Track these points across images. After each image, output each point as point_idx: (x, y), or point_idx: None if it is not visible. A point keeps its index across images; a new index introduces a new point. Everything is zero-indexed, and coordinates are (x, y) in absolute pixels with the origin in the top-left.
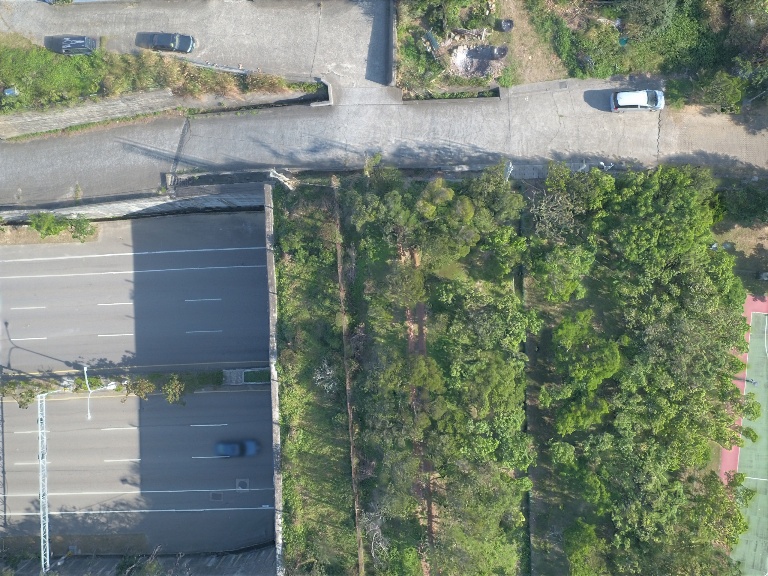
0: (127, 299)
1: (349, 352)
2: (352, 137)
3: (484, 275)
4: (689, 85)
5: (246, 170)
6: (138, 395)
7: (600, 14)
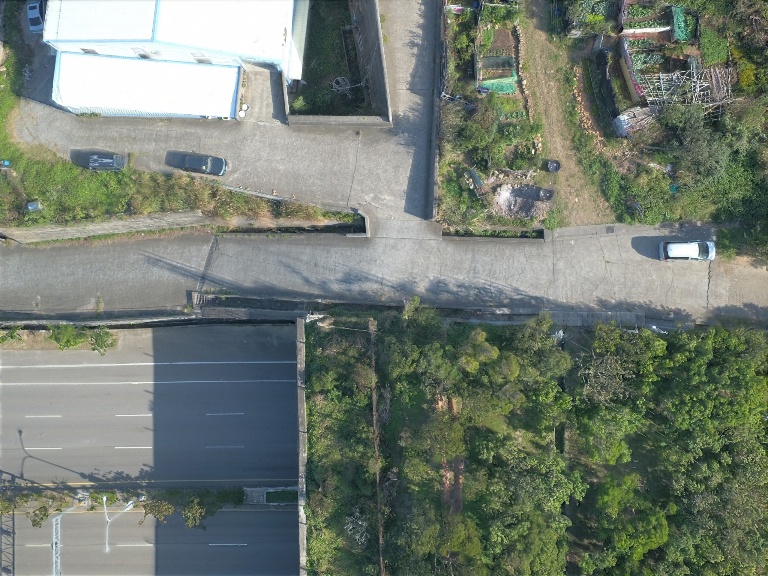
0: (146, 411)
1: (382, 501)
2: (389, 271)
3: (524, 424)
4: (741, 236)
5: (277, 298)
6: (157, 518)
7: (650, 160)
